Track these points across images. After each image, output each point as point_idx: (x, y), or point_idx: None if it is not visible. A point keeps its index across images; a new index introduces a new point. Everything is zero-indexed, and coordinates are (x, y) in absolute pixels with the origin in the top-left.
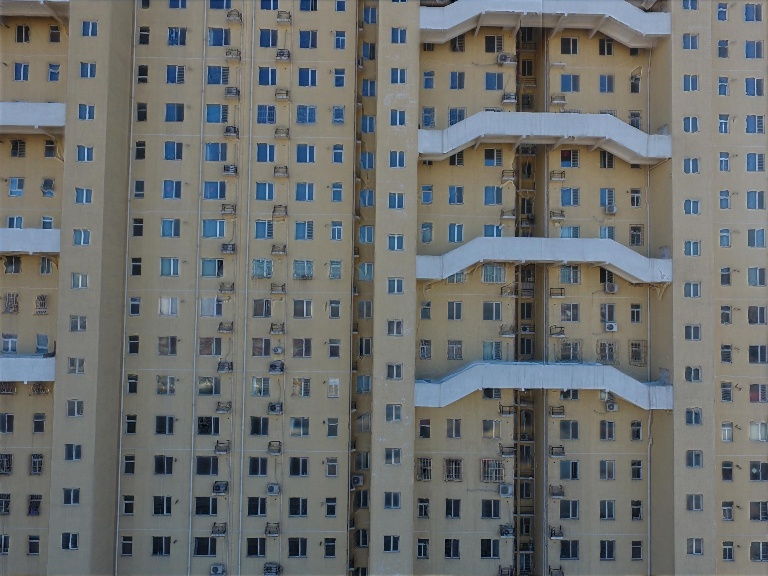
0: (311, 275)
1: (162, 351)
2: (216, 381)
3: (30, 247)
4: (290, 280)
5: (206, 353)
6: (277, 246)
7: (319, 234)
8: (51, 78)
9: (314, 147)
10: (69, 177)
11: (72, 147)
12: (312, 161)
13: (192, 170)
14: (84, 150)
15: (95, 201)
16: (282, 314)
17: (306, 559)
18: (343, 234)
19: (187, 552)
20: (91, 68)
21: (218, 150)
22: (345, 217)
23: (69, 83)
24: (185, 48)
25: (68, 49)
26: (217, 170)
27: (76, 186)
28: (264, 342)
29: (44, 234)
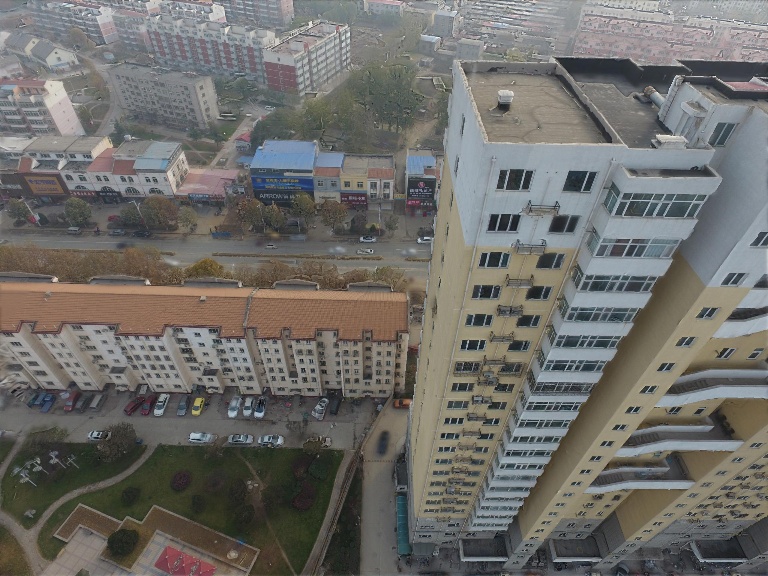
0: None
1: None
2: (762, 465)
3: (714, 448)
4: None
5: (765, 456)
6: None
7: None
8: None
9: None
10: None
11: None
12: None
13: None
14: None
15: None
16: None
17: (755, 509)
18: None
19: (692, 508)
20: None
21: None
22: None
23: None
24: None
25: None
26: None
27: None
28: None
29: (730, 444)
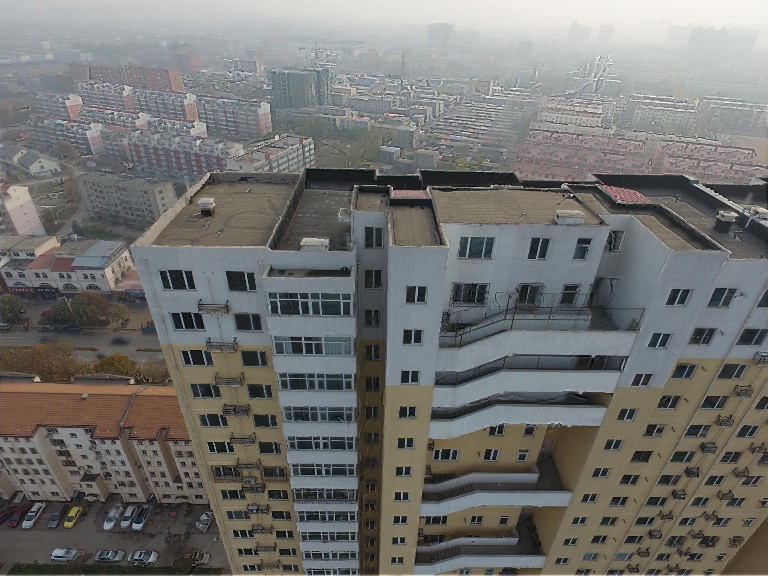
0: (714, 545)
1: (577, 573)
2: None
3: (519, 565)
4: (695, 546)
5: (609, 573)
6: (697, 534)
7: (734, 526)
8: (526, 432)
9: (762, 477)
10: (562, 534)
11: (570, 519)
12: (754, 484)
13: (642, 492)
14: (579, 518)
15: (580, 545)
16: (678, 560)
17: None
18: (753, 524)
19: None
20: (603, 470)
21: (671, 478)
22: (762, 516)
23: (581, 483)
24: (674, 412)
25: (587, 460)
26: (665, 492)
27: (566, 538)
28: (656, 570)
29: (532, 560)
